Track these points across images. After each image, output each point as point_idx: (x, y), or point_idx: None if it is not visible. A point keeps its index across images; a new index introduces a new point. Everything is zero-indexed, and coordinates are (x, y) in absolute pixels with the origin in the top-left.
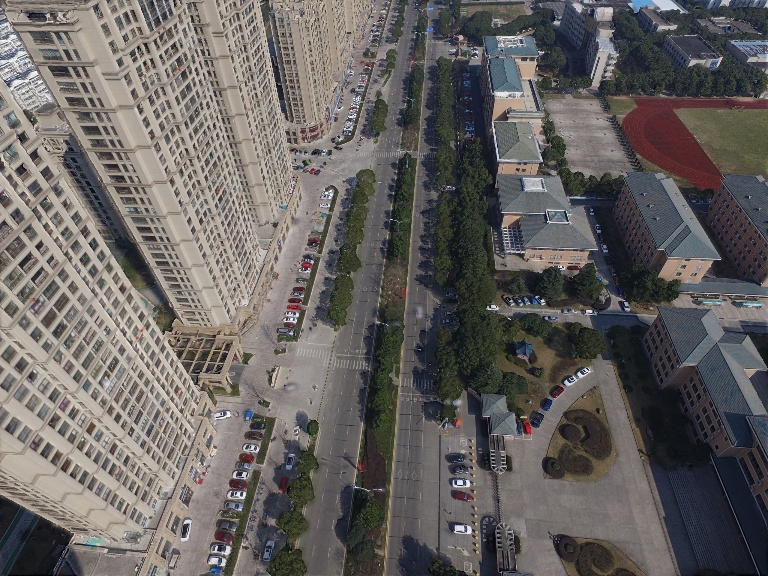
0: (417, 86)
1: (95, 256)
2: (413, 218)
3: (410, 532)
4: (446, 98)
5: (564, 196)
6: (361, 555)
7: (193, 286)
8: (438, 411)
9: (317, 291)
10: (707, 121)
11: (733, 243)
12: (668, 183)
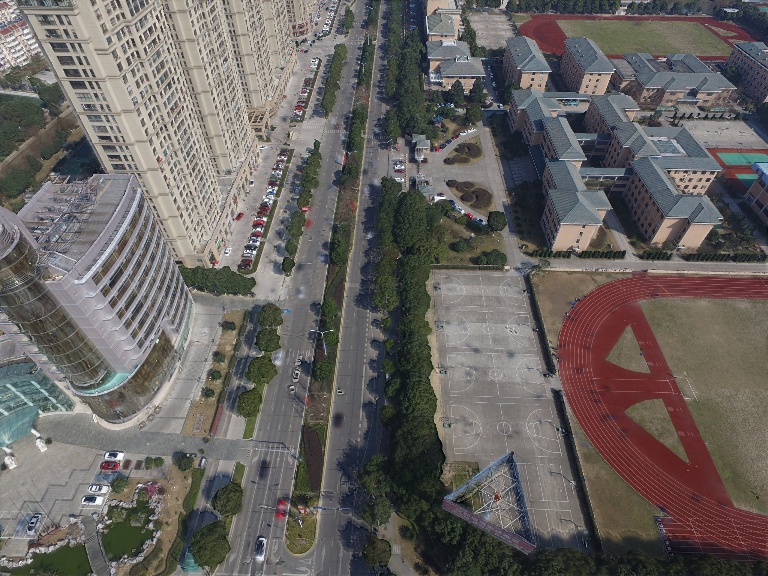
0: (375, 4)
1: (219, 1)
2: (373, 73)
3: (372, 183)
4: (396, 10)
5: (468, 50)
6: (347, 182)
7: (244, 71)
8: (388, 146)
9: (312, 104)
10: (576, 26)
11: (569, 77)
12: (530, 40)
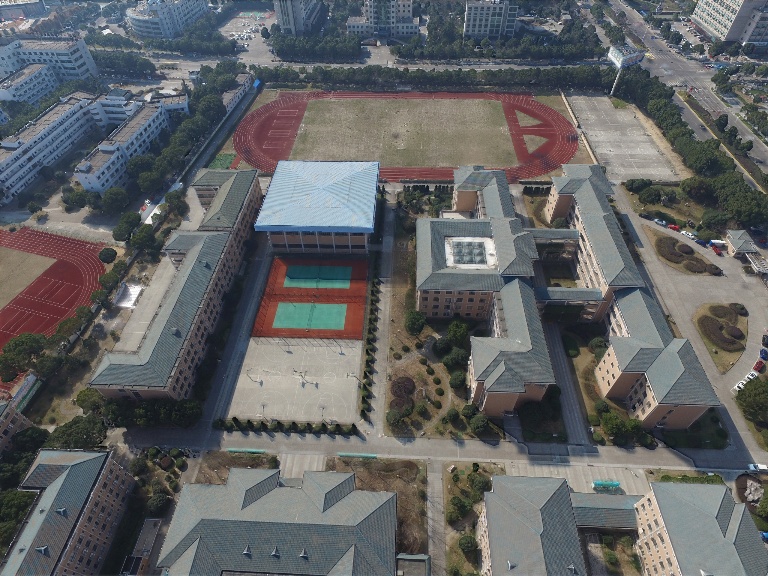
0: None
1: None
2: None
3: None
4: None
5: None
6: None
7: None
8: None
9: None
10: None
11: None
12: None
